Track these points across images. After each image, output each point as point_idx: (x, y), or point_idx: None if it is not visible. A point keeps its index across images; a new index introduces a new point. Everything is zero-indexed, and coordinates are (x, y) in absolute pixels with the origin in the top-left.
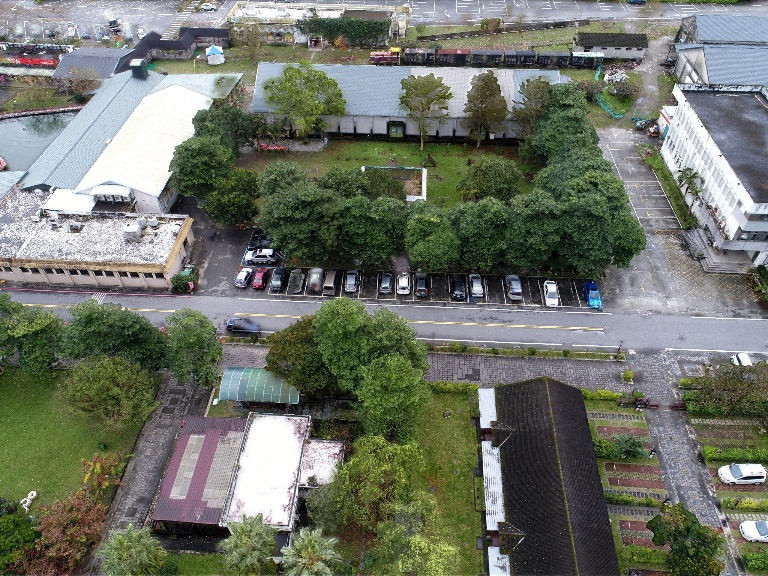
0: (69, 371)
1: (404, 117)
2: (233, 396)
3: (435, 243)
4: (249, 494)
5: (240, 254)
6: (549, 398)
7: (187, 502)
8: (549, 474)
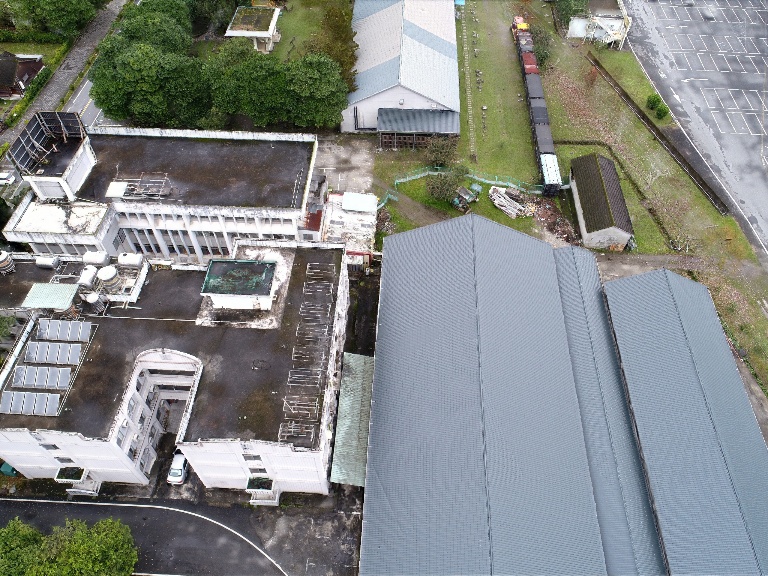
0: None
1: None
2: None
3: (131, 8)
4: None
5: None
6: (2, 59)
7: None
8: None
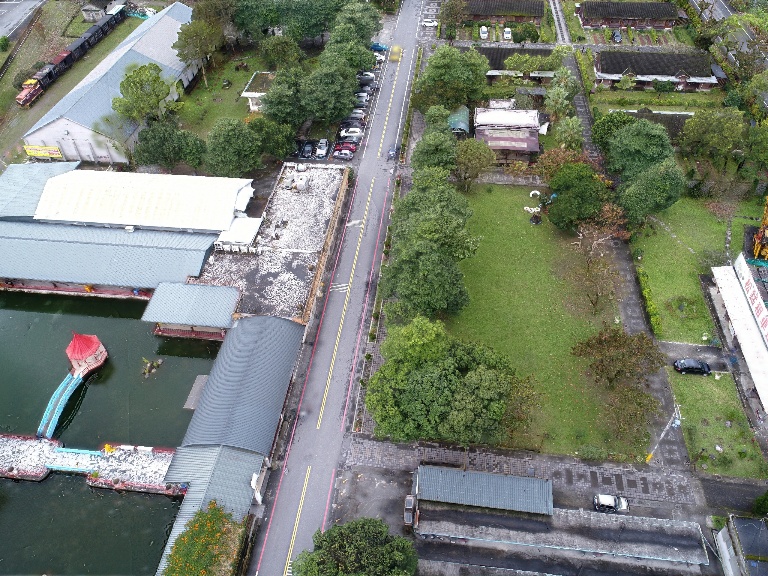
0: (465, 167)
1: (180, 75)
2: (467, 127)
3: None
4: (522, 122)
5: (314, 161)
6: None
7: (528, 142)
8: (502, 52)
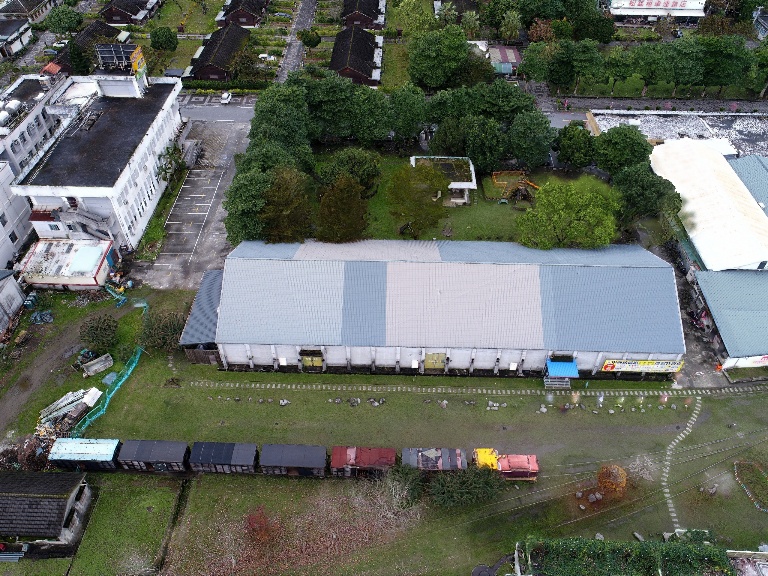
0: None
1: None
2: None
3: None
4: None
5: None
6: (348, 59)
7: None
8: None
